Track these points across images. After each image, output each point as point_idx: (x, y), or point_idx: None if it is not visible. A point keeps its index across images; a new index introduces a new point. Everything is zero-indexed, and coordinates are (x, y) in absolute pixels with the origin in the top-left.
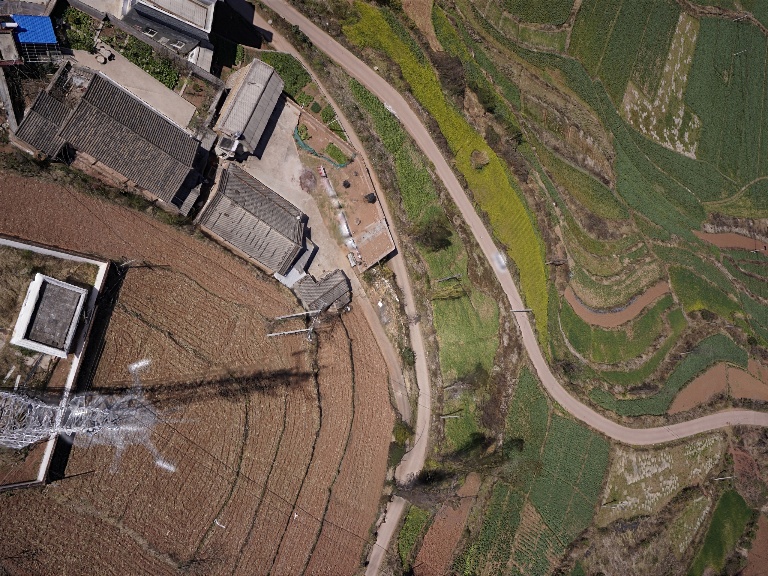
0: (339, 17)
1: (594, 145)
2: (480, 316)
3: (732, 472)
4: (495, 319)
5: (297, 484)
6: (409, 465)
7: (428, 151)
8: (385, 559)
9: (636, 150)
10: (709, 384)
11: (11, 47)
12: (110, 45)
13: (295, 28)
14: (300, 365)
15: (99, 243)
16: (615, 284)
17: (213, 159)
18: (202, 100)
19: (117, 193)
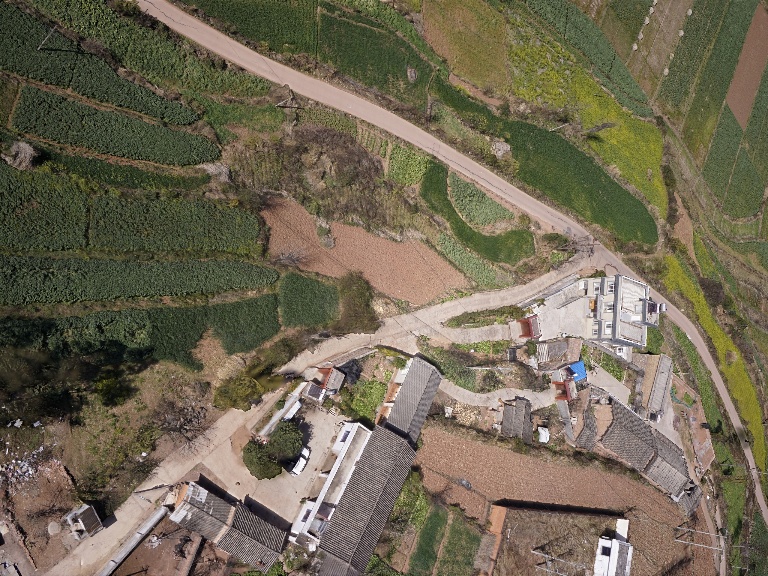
0: (658, 272)
1: None
2: None
3: None
4: None
5: None
6: None
7: (707, 362)
8: None
9: None
10: None
11: (573, 388)
12: None
13: None
14: (687, 555)
15: (610, 501)
16: None
17: None
18: (631, 383)
19: (617, 468)
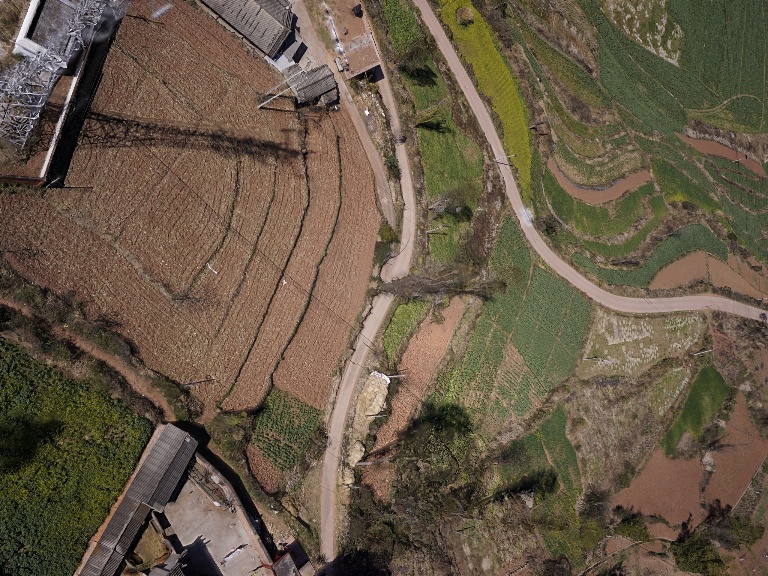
0: None
1: (578, 35)
2: (464, 157)
3: (711, 351)
4: (479, 164)
5: (286, 252)
6: (394, 269)
7: None
8: (371, 350)
9: (619, 48)
10: (689, 269)
11: None
12: None
13: None
14: (289, 142)
15: None
16: (598, 165)
17: None
18: None
19: None
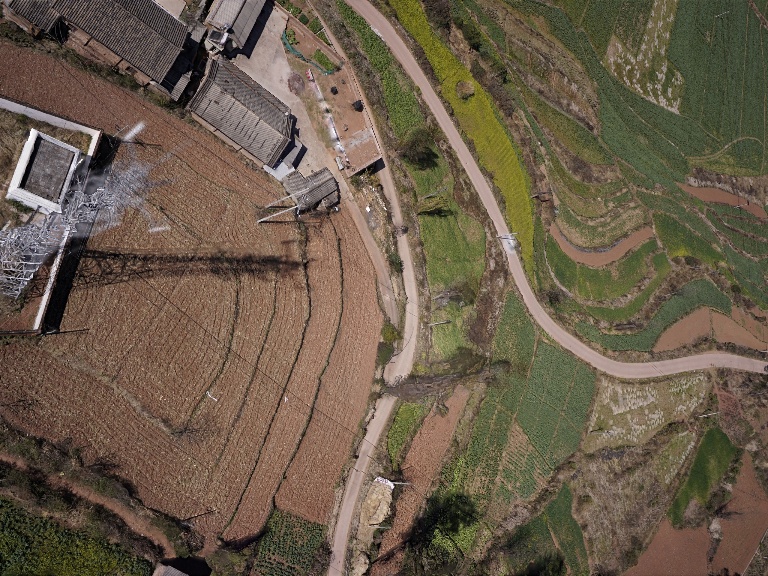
0: None
1: (578, 92)
2: (467, 238)
3: (716, 411)
4: (481, 242)
5: (287, 368)
6: (397, 368)
7: (414, 76)
8: (374, 455)
9: (620, 101)
10: (693, 326)
11: None
12: None
13: None
14: (289, 254)
15: (92, 117)
16: (600, 225)
17: (203, 53)
18: None
19: (109, 70)
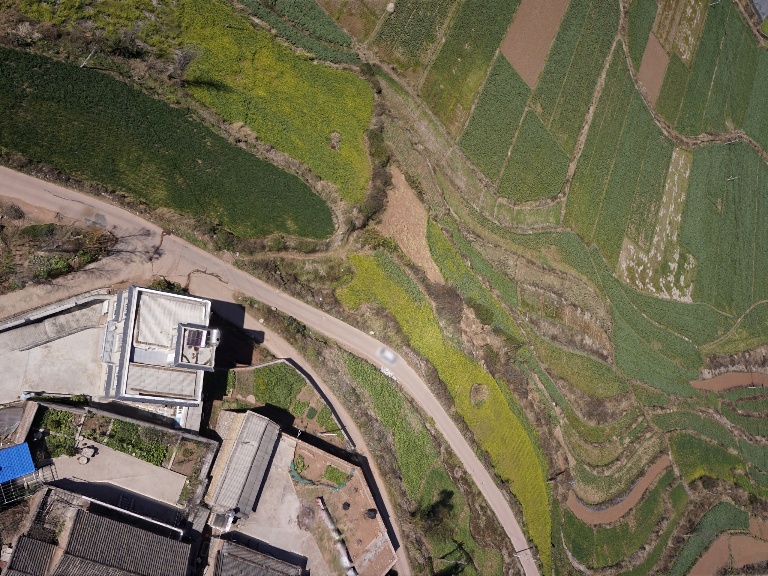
0: (332, 279)
1: (592, 320)
2: (484, 575)
3: None
4: (499, 572)
5: None
6: None
7: (427, 406)
8: None
9: (633, 311)
10: (712, 560)
11: None
12: (93, 439)
13: (288, 322)
14: None
15: None
16: (616, 472)
17: (206, 530)
18: (192, 464)
19: None
